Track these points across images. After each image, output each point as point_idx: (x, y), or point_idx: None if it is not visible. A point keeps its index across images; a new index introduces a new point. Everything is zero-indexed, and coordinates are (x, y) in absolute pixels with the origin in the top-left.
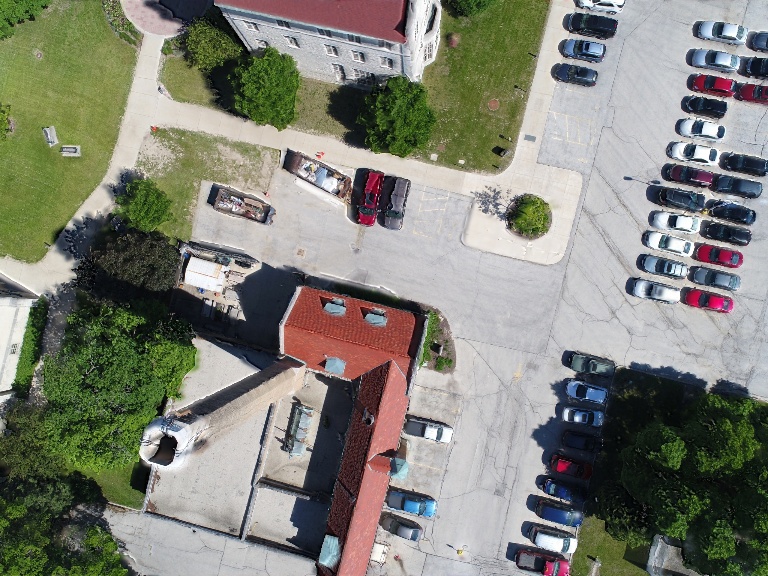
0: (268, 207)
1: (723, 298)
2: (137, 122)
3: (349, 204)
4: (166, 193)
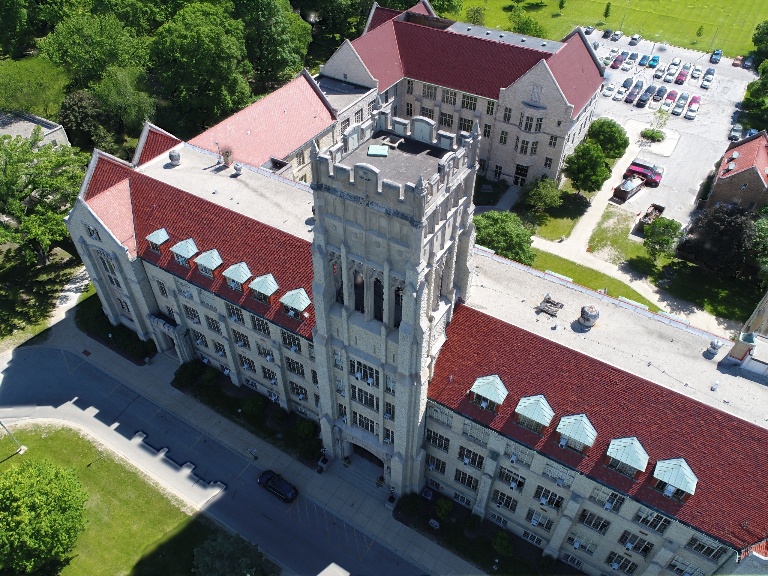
0: (653, 205)
1: (695, 96)
2: (582, 257)
3: (646, 186)
4: (638, 255)
